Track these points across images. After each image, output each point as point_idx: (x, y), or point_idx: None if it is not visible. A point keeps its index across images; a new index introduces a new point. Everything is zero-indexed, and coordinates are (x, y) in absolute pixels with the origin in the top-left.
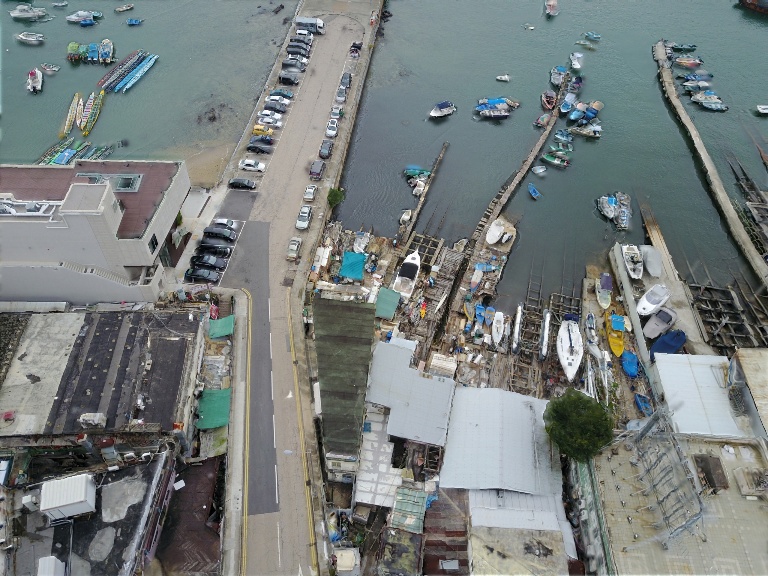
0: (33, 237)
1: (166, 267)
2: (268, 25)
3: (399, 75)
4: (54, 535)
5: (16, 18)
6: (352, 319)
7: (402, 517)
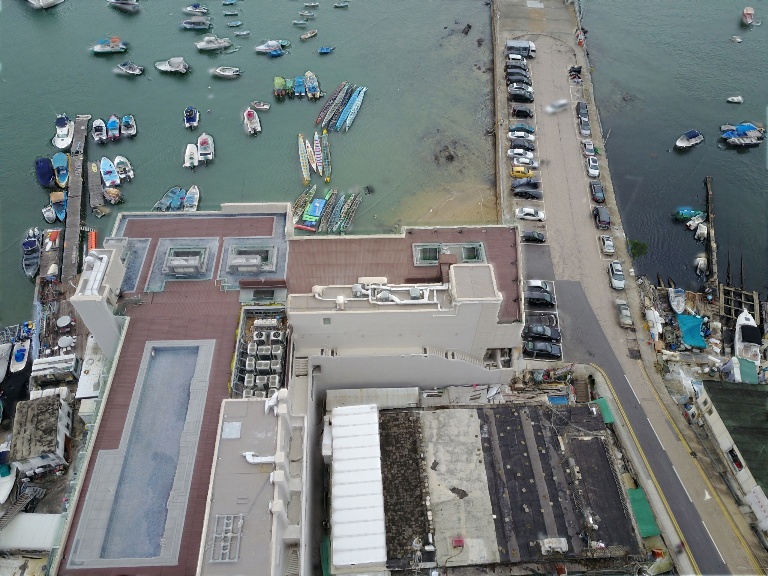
0: (411, 325)
1: None
2: (464, 48)
3: (623, 100)
4: None
5: (202, 50)
6: (758, 406)
7: None
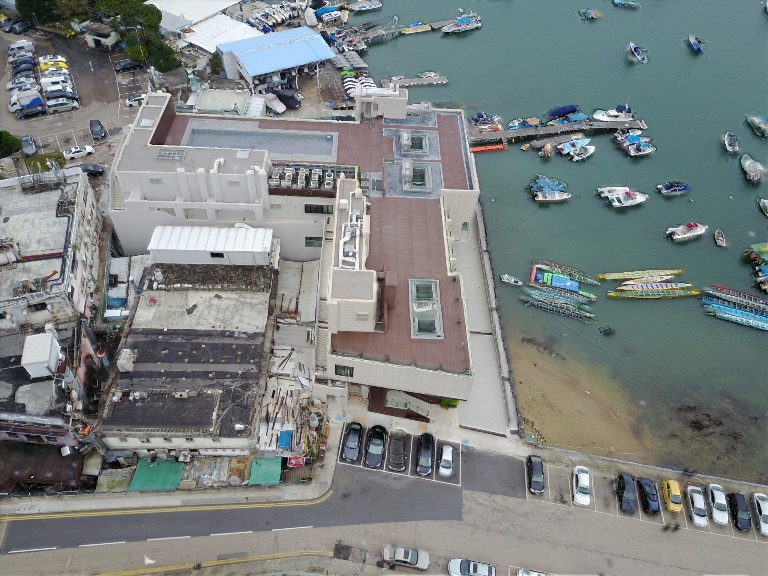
0: None
1: (368, 402)
2: None
3: None
4: None
5: None
6: None
7: None
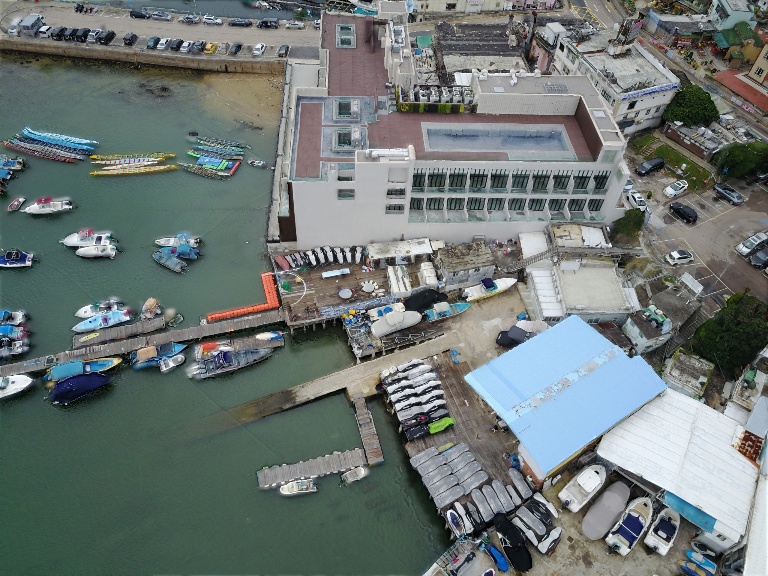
0: None
1: None
2: None
3: (120, 5)
4: None
5: None
6: None
7: None
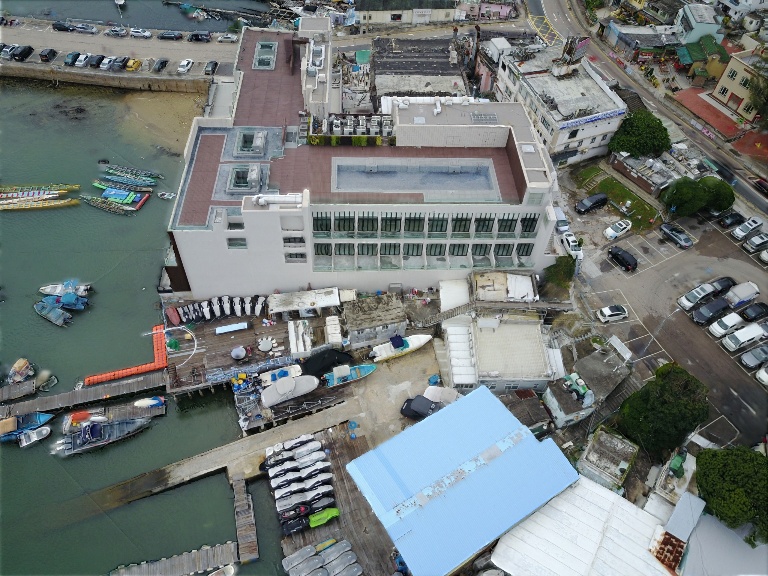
0: None
1: None
2: None
3: (47, 16)
4: None
5: None
6: None
7: (474, 2)
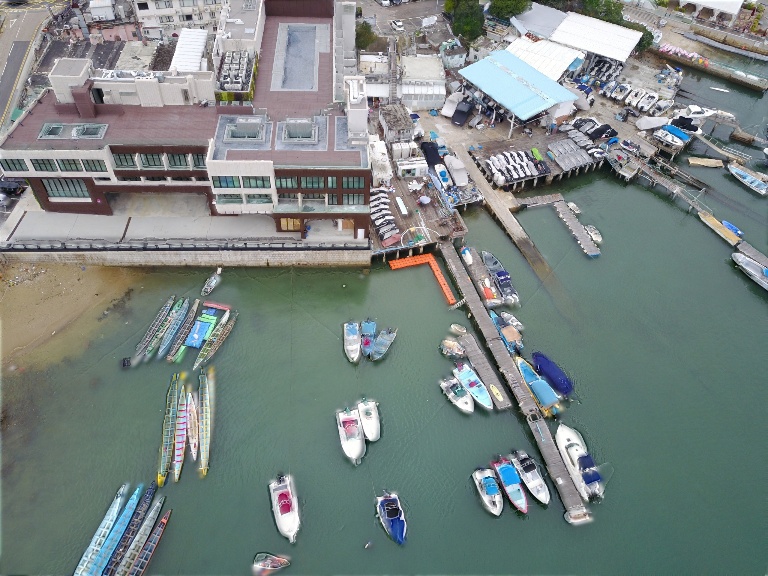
0: None
1: None
2: None
3: None
4: (114, 11)
5: None
6: None
7: None
